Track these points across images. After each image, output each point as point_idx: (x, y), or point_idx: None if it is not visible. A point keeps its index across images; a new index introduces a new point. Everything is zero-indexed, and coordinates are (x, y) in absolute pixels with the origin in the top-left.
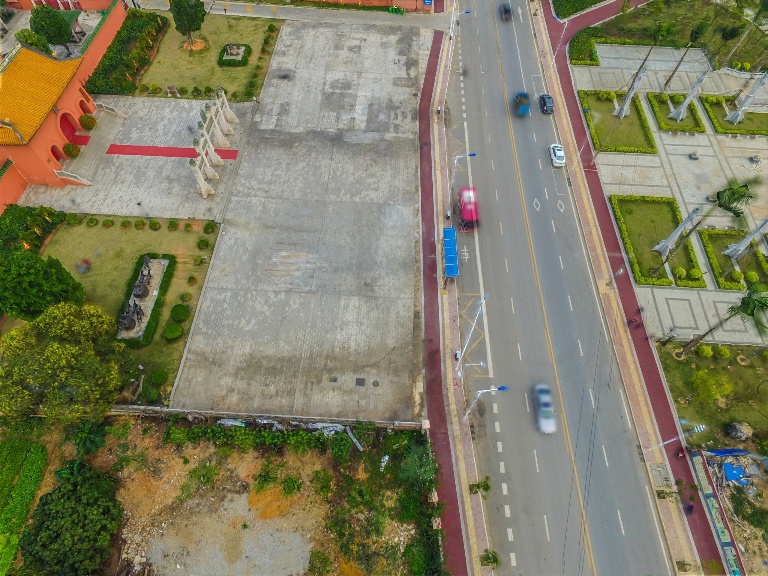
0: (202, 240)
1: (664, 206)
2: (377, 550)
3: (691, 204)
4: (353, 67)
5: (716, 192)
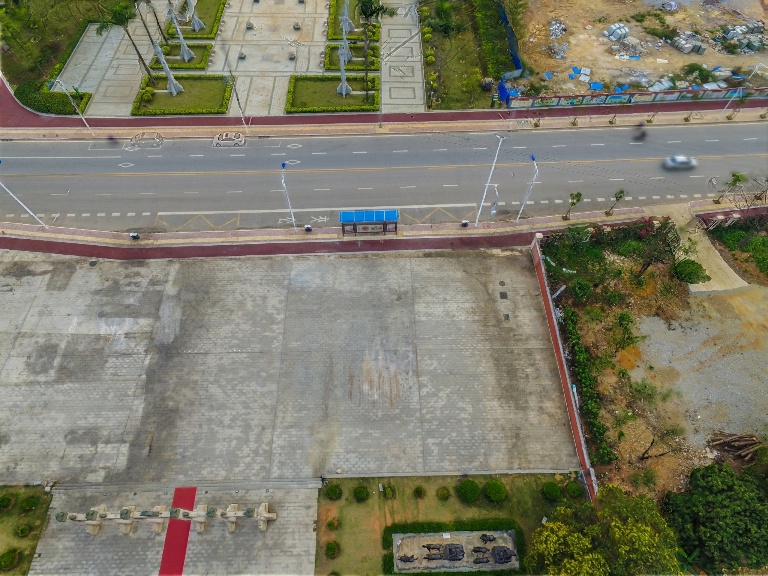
0: (358, 493)
1: (298, 83)
2: (630, 272)
3: (296, 69)
4: (0, 346)
5: (284, 53)
